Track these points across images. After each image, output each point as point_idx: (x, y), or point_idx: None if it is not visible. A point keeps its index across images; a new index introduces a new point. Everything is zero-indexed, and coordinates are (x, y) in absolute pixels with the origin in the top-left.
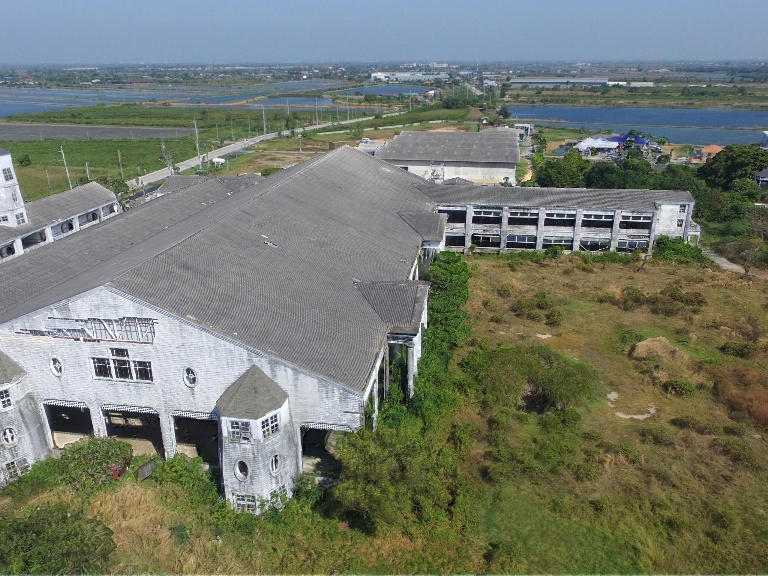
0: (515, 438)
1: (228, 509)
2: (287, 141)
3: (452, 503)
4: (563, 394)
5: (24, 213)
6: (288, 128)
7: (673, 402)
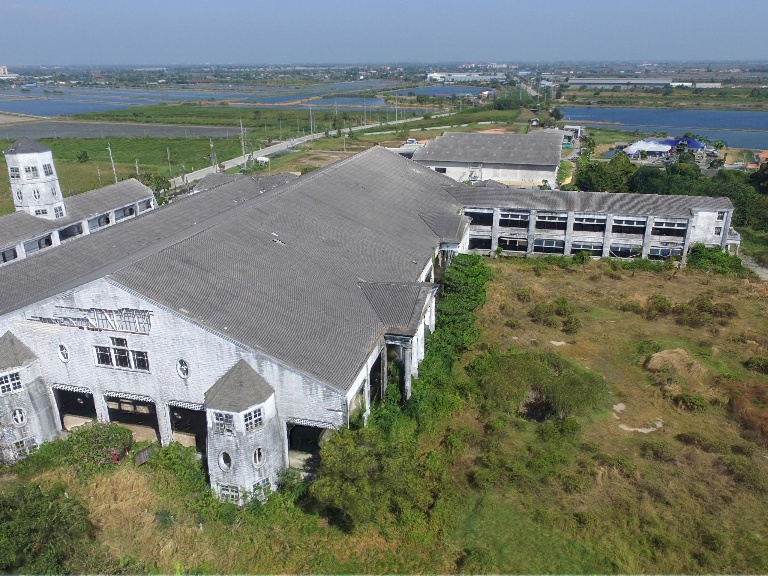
0: (509, 445)
1: (213, 498)
2: (333, 141)
3: (431, 506)
4: (565, 403)
5: (63, 207)
6: (335, 128)
7: (682, 417)
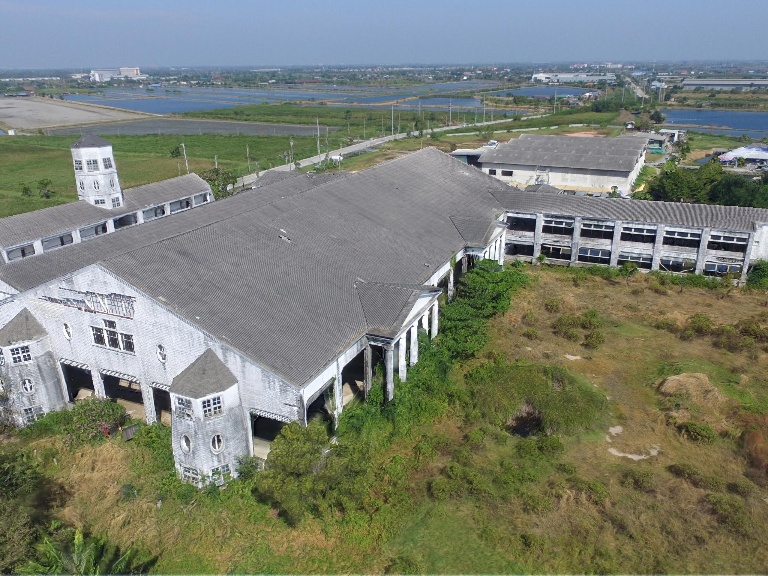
0: (483, 457)
1: (176, 478)
2: (414, 141)
3: (376, 510)
4: (553, 420)
5: (120, 197)
6: (417, 128)
7: (683, 447)
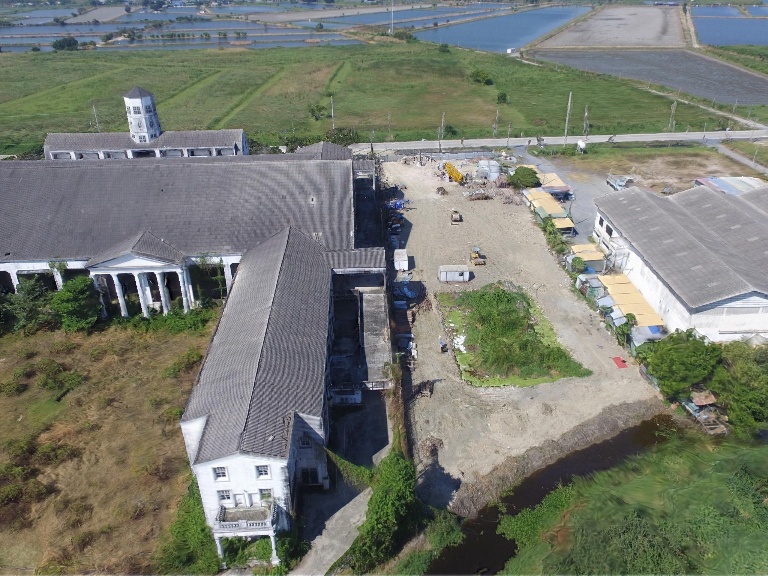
0: None
1: None
2: None
3: None
4: None
5: (147, 136)
6: None
7: None
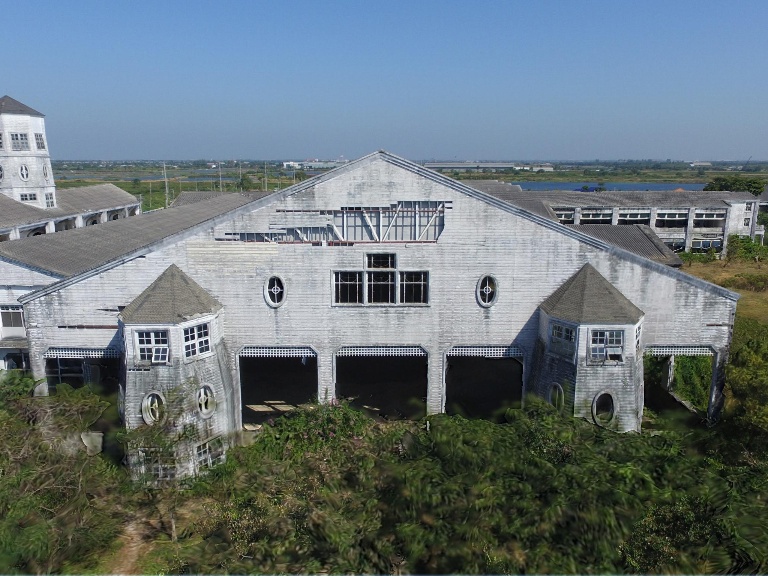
0: None
1: None
2: None
3: None
4: None
5: (53, 194)
6: (243, 187)
7: None
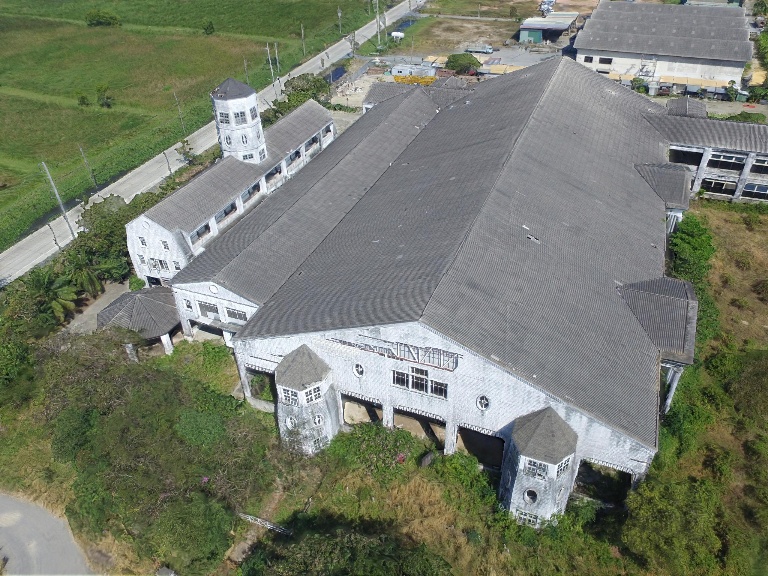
0: None
1: (510, 519)
2: None
3: (724, 552)
4: None
5: (265, 148)
6: None
7: None
